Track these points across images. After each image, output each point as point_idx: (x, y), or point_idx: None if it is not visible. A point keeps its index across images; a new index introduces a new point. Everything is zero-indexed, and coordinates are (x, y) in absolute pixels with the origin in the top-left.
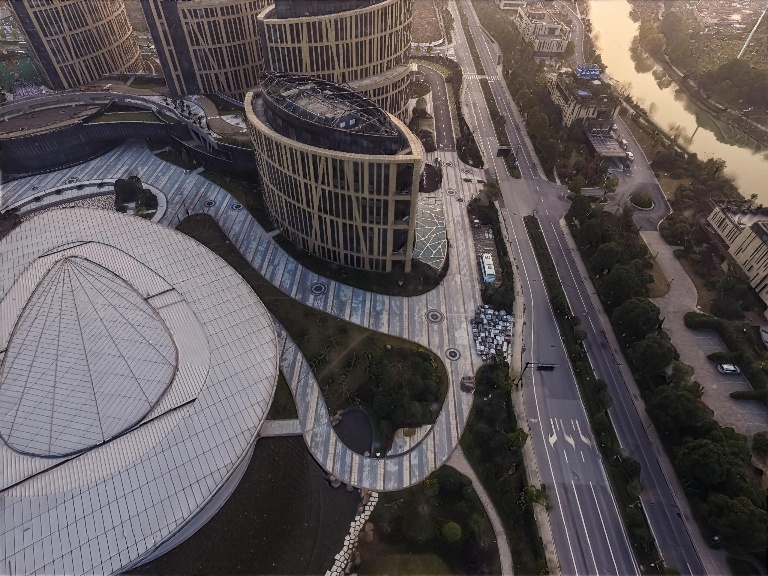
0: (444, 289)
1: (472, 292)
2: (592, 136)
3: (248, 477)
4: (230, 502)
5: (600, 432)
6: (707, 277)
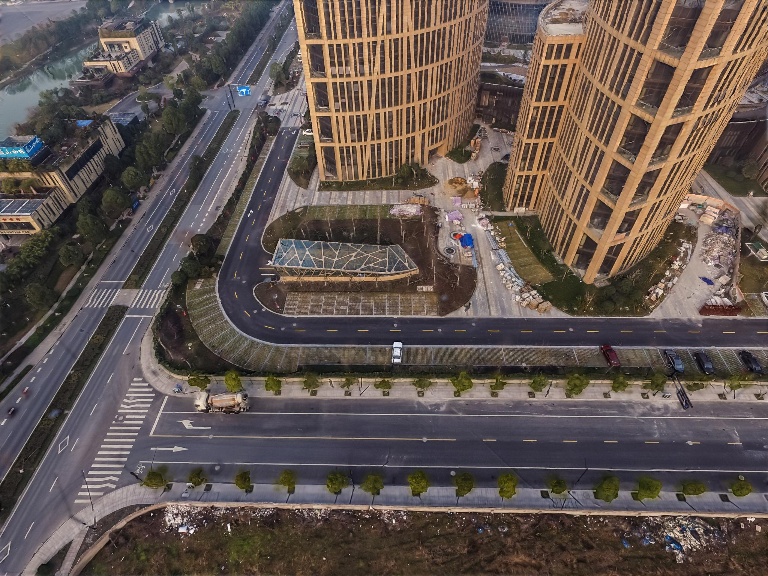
0: None
1: None
2: None
3: None
4: None
5: None
6: None
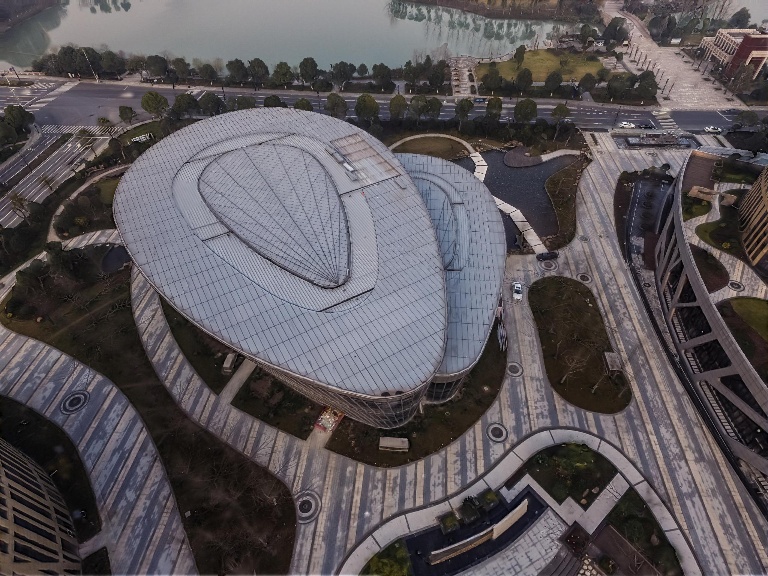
0: None
1: None
2: None
3: None
4: None
5: None
6: None
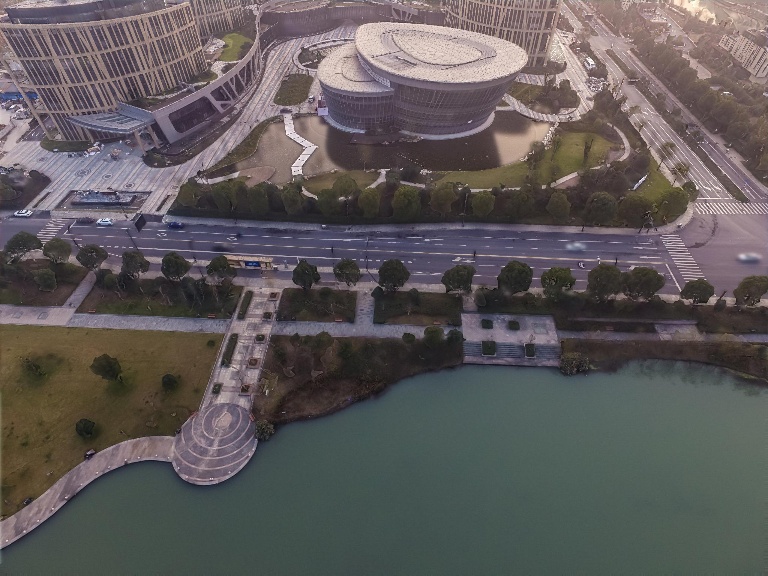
0: (567, 73)
1: (583, 74)
2: (643, 14)
3: (496, 120)
4: (492, 125)
5: (660, 107)
6: (717, 68)
